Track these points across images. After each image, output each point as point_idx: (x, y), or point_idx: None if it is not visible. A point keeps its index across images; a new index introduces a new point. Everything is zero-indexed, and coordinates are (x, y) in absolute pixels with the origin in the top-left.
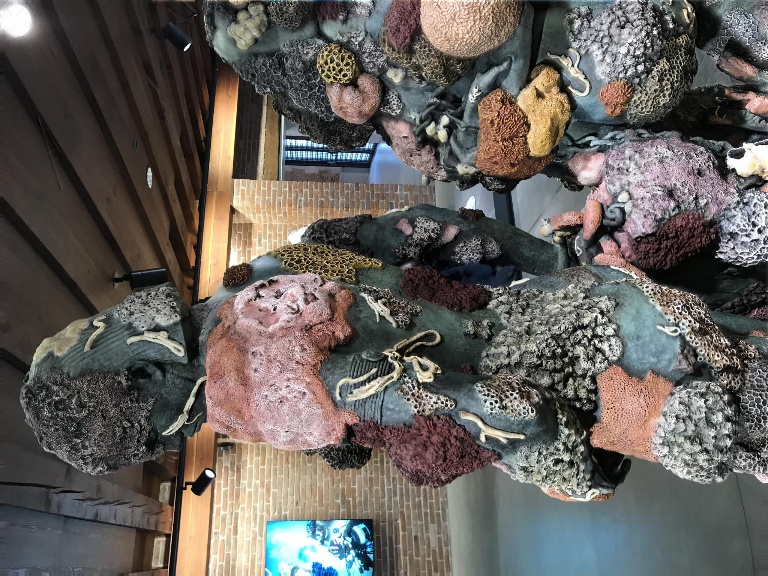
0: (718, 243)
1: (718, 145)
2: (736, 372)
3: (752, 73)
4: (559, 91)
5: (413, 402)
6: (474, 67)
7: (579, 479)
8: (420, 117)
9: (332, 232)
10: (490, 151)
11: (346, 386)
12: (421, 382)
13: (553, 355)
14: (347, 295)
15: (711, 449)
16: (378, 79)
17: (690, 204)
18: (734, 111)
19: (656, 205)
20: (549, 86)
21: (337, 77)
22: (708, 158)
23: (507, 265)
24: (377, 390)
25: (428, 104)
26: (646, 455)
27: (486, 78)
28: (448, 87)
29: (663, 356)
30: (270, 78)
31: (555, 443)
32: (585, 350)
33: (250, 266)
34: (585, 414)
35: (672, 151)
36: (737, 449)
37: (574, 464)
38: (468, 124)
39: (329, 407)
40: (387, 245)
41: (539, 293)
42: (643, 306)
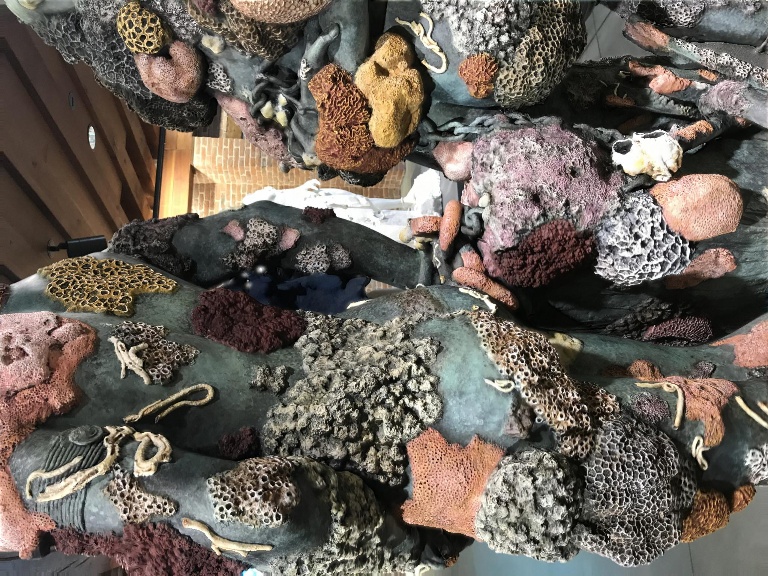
0: (596, 257)
1: (607, 134)
2: (586, 434)
3: (661, 43)
4: (407, 67)
5: (121, 505)
6: (303, 35)
7: (395, 561)
8: (252, 96)
9: (140, 238)
10: (325, 141)
11: (38, 481)
12: (136, 476)
13: (348, 419)
14: (82, 344)
15: (540, 539)
16: (194, 49)
17: (559, 212)
18: (637, 89)
19: (516, 213)
20: (393, 61)
21: (140, 46)
22: (584, 154)
23: (359, 276)
24: (75, 489)
25: (256, 81)
26: (473, 535)
27: (313, 50)
28: (278, 60)
29: (491, 418)
30: (70, 45)
31: (324, 547)
32: (388, 413)
33: (9, 289)
34: (394, 489)
35: (540, 145)
36: (582, 529)
37: (368, 558)
38: (306, 106)
39: (15, 509)
40: (213, 253)
41: (362, 326)
42: (472, 352)
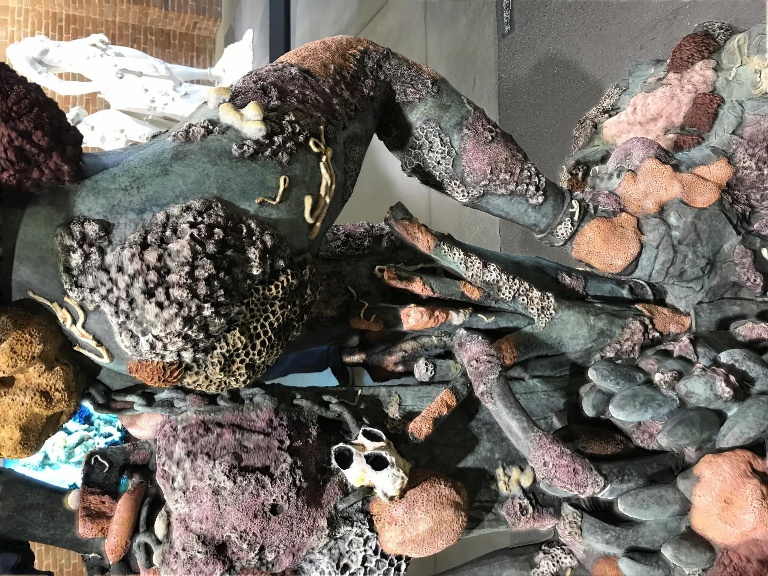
0: None
1: (333, 411)
2: None
3: (425, 249)
4: (44, 371)
5: None
6: None
7: None
8: None
9: None
10: None
11: None
12: None
13: None
14: None
15: None
16: None
17: (250, 560)
18: (388, 309)
19: (194, 571)
20: (18, 370)
21: None
22: (290, 485)
23: (9, 549)
24: None
25: None
26: None
27: None
28: None
29: None
30: None
31: None
32: None
33: None
34: None
35: (233, 481)
36: None
37: None
38: None
39: None
40: None
41: None
42: None
